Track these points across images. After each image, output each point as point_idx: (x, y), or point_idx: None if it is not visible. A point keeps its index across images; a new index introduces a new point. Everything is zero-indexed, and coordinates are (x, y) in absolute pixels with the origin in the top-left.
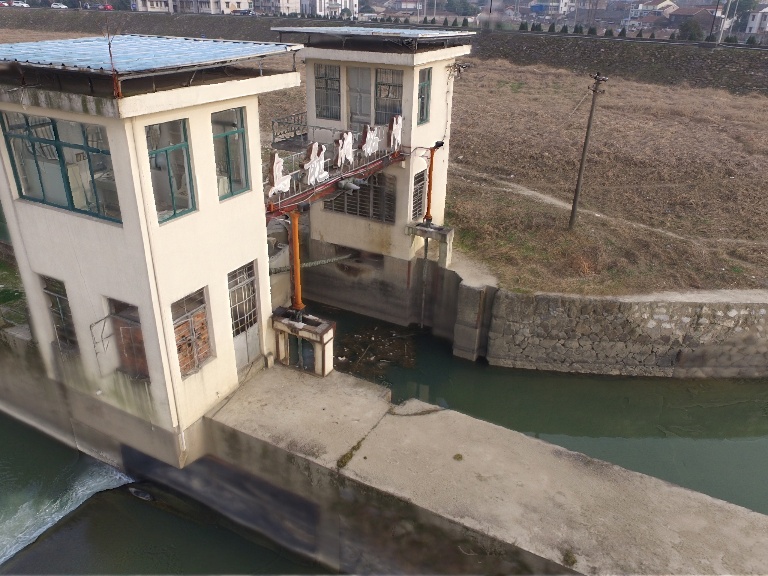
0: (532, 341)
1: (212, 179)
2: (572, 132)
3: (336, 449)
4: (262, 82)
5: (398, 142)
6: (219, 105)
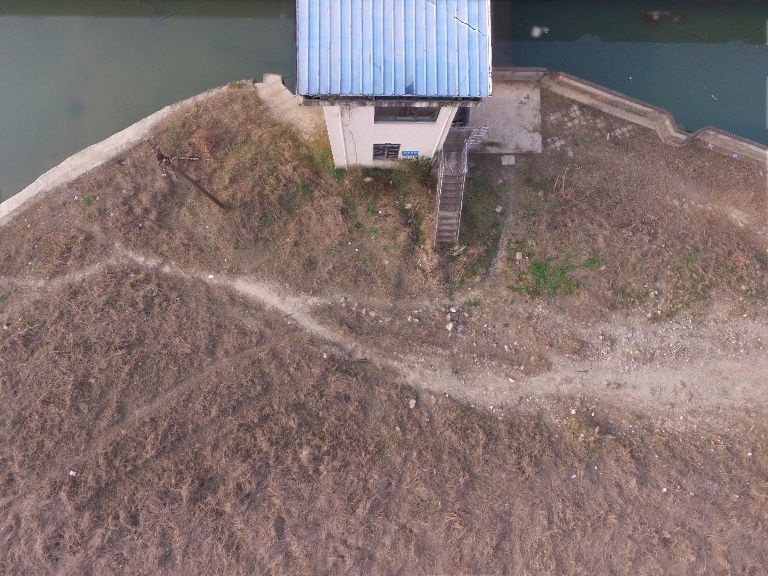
0: None
1: None
2: None
3: None
4: None
5: None
6: None
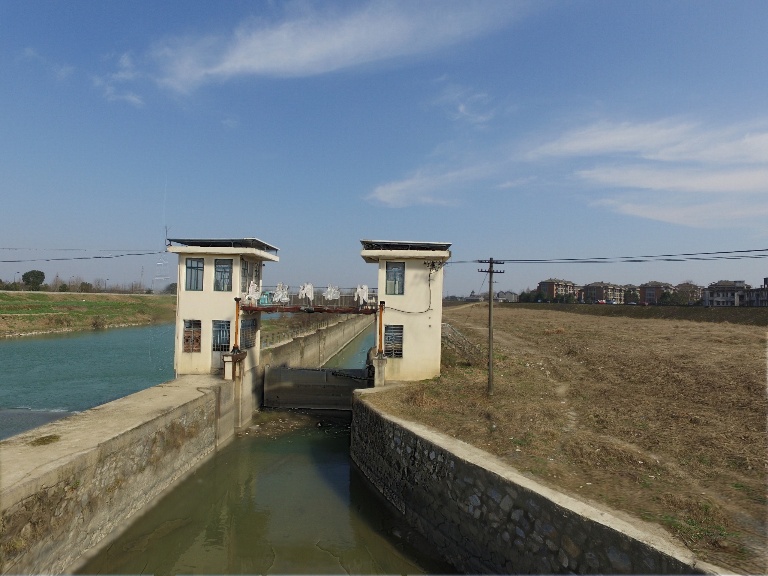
0: None
1: (211, 281)
2: None
3: None
4: (231, 249)
5: (364, 300)
6: (219, 256)
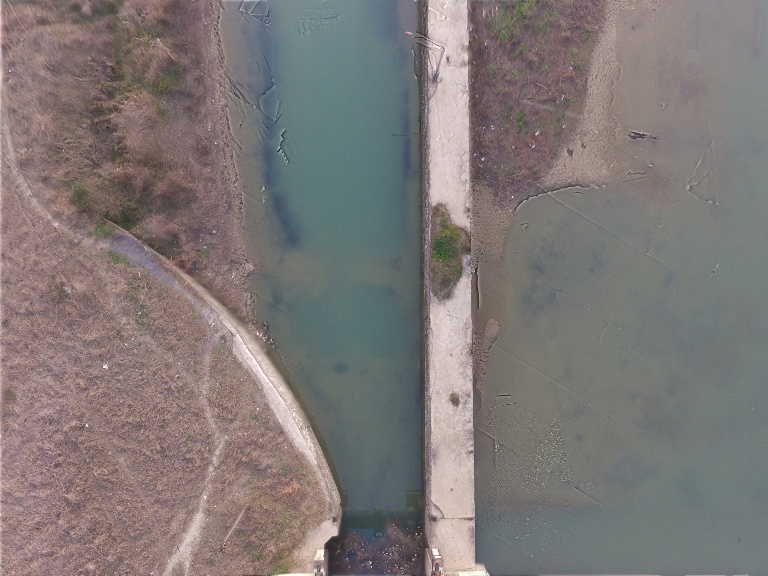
0: (334, 489)
1: None
2: (11, 567)
3: (468, 524)
4: None
5: None
6: None
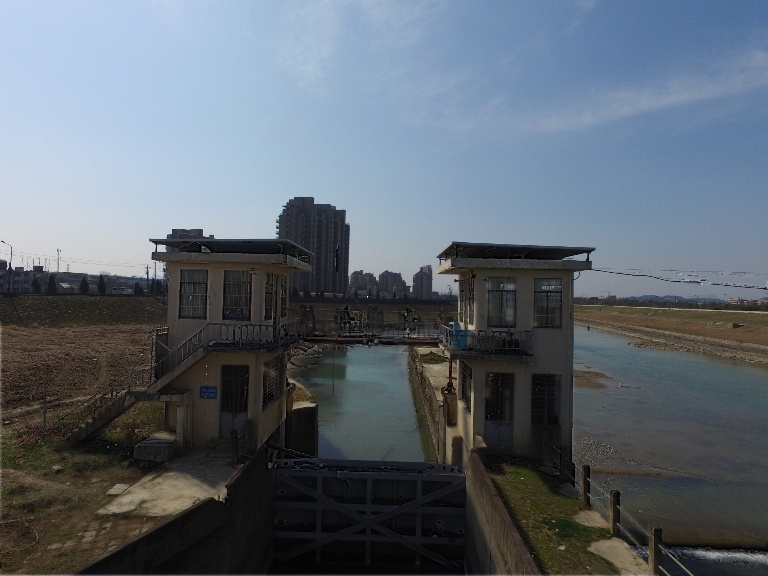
0: None
1: None
2: None
3: None
4: None
5: None
6: None
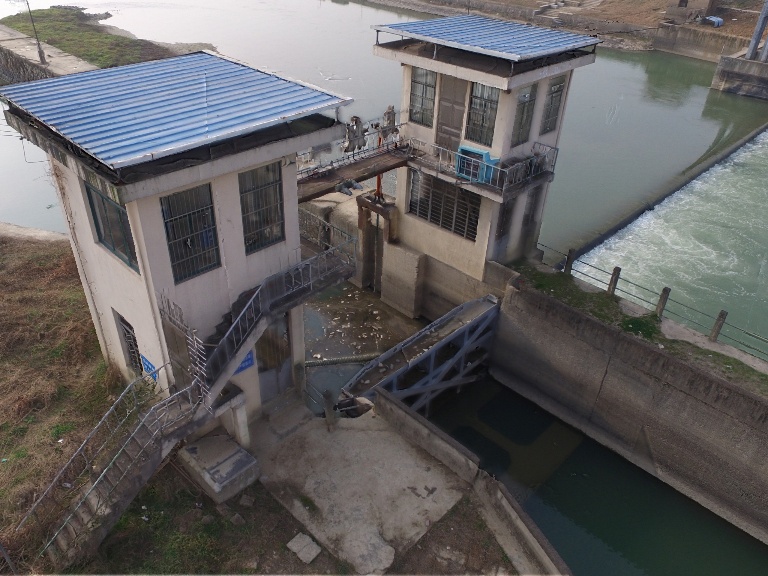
0: None
1: None
2: None
3: None
4: None
5: None
6: None
